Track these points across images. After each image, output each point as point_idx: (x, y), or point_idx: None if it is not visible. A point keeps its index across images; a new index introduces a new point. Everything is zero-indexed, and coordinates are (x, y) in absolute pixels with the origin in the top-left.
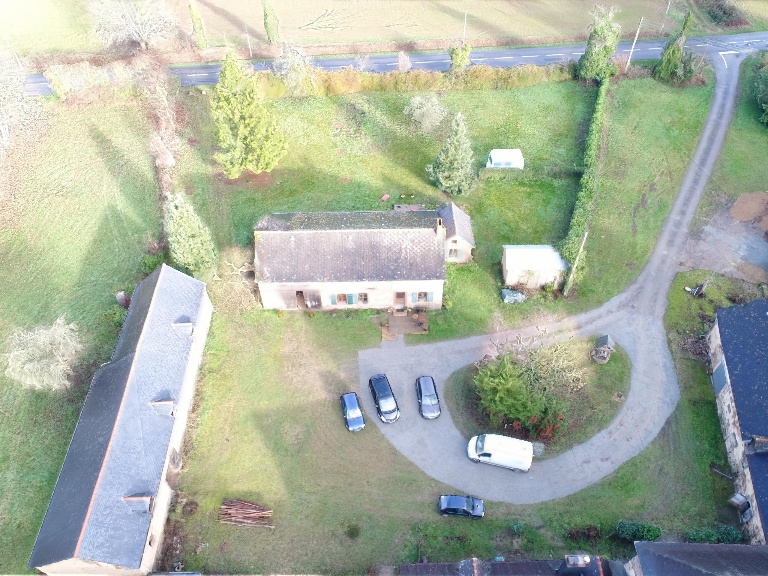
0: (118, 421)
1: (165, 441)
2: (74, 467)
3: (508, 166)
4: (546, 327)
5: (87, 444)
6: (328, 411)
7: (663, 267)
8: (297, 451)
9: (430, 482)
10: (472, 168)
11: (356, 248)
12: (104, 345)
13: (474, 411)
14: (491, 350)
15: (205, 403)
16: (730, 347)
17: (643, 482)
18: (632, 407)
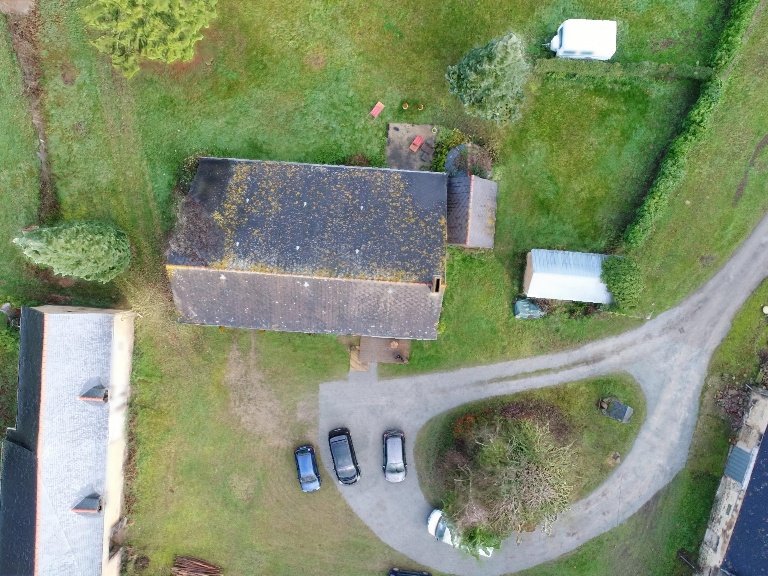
0: (38, 549)
1: (98, 541)
2: (8, 568)
3: (586, 54)
4: (559, 357)
5: (14, 549)
6: (281, 462)
7: (751, 266)
8: (247, 507)
9: (384, 549)
10: (528, 41)
11: (314, 296)
12: (7, 364)
13: (444, 472)
14: (482, 389)
15: (142, 447)
16: (767, 455)
17: (602, 562)
18: (624, 474)
